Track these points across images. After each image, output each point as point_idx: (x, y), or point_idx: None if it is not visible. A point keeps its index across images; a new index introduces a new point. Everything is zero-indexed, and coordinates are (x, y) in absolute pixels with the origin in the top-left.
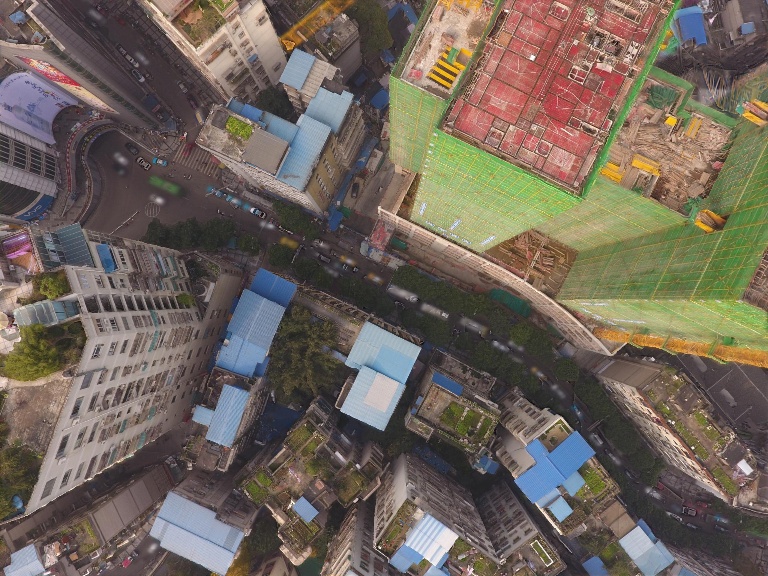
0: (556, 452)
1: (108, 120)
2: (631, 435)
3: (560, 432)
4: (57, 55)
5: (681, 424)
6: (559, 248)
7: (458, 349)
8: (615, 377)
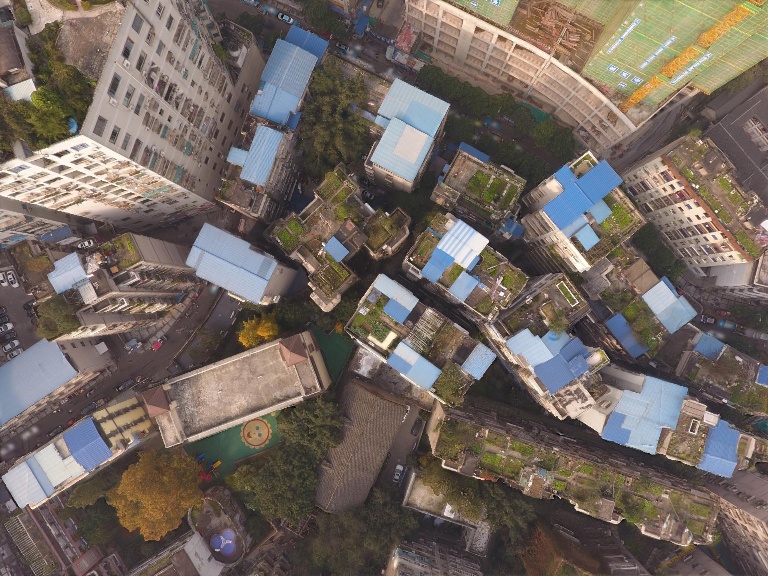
0: (584, 178)
1: None
2: (652, 232)
3: (587, 168)
4: None
5: (705, 189)
6: (585, 25)
7: None
8: (638, 166)
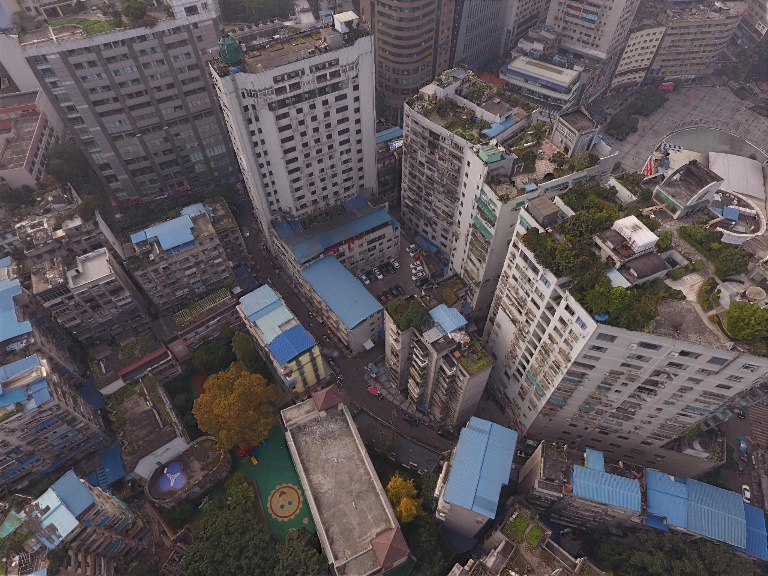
0: None
1: None
2: None
3: None
4: None
5: None
6: None
7: None
8: None
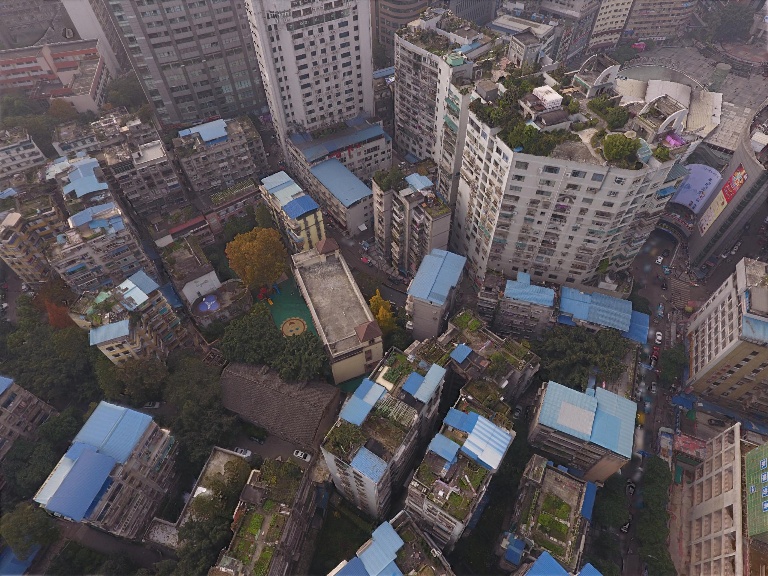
0: None
1: (690, 233)
2: None
3: None
4: (761, 179)
5: None
6: None
7: (589, 547)
8: None
